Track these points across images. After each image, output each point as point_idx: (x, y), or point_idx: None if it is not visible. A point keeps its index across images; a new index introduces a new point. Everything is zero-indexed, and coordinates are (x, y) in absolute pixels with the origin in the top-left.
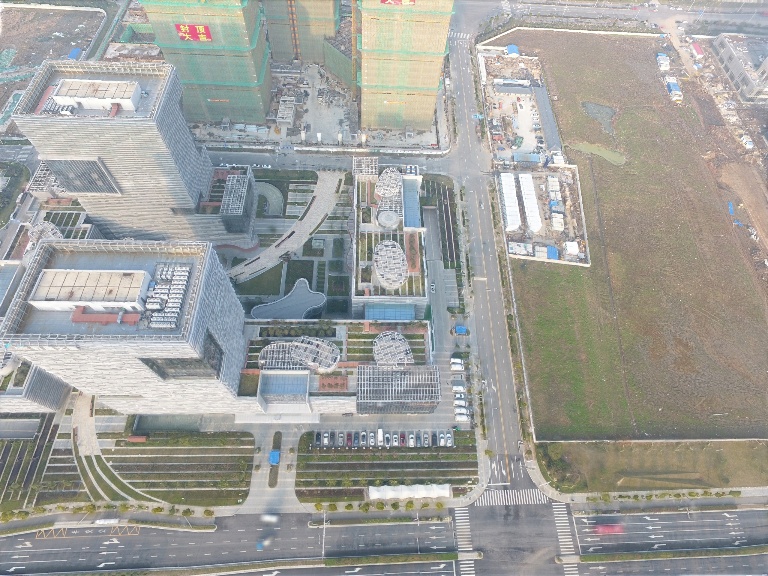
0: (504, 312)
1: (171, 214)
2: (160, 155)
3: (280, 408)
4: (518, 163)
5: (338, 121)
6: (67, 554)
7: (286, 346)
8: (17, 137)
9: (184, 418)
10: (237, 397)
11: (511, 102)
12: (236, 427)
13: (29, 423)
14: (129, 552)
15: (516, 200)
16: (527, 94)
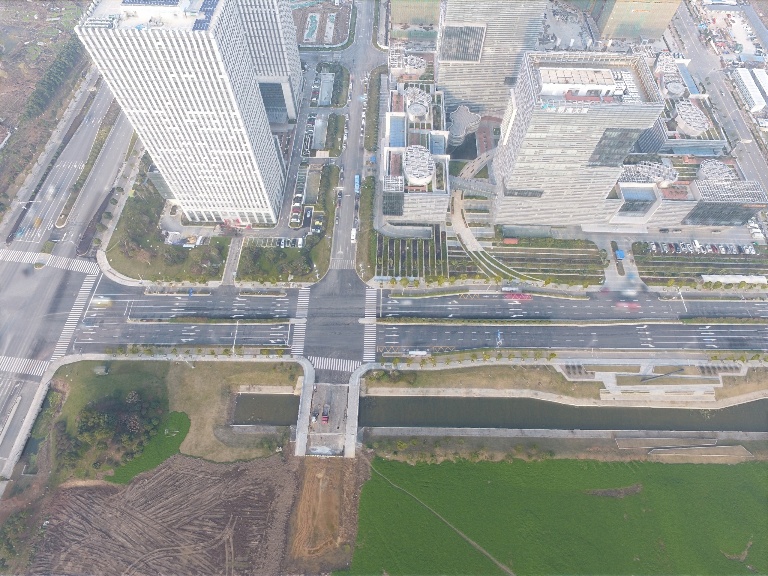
0: (767, 168)
1: (502, 84)
2: (535, 21)
3: (620, 219)
4: (746, 62)
5: (578, 33)
6: (486, 309)
7: (631, 168)
8: (329, 45)
9: (536, 231)
10: (606, 199)
11: (722, 18)
12: (579, 237)
13: (419, 232)
14: (531, 309)
15: (757, 87)
16: (737, 11)
